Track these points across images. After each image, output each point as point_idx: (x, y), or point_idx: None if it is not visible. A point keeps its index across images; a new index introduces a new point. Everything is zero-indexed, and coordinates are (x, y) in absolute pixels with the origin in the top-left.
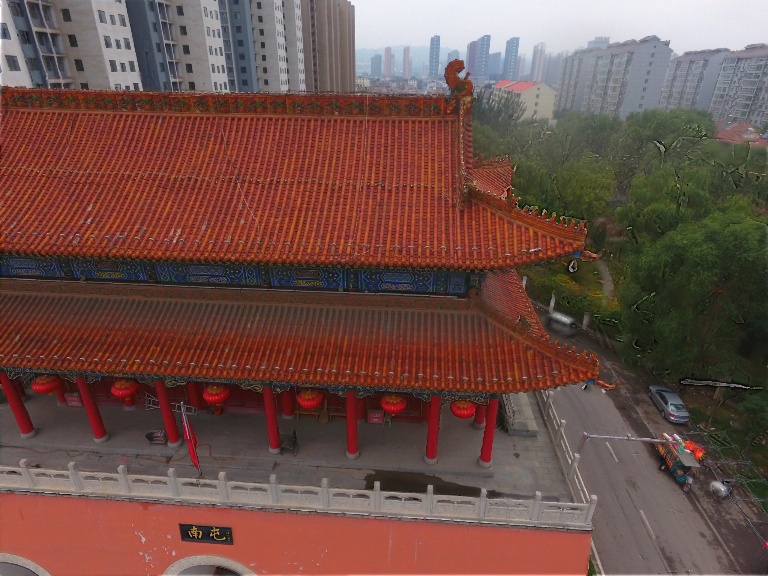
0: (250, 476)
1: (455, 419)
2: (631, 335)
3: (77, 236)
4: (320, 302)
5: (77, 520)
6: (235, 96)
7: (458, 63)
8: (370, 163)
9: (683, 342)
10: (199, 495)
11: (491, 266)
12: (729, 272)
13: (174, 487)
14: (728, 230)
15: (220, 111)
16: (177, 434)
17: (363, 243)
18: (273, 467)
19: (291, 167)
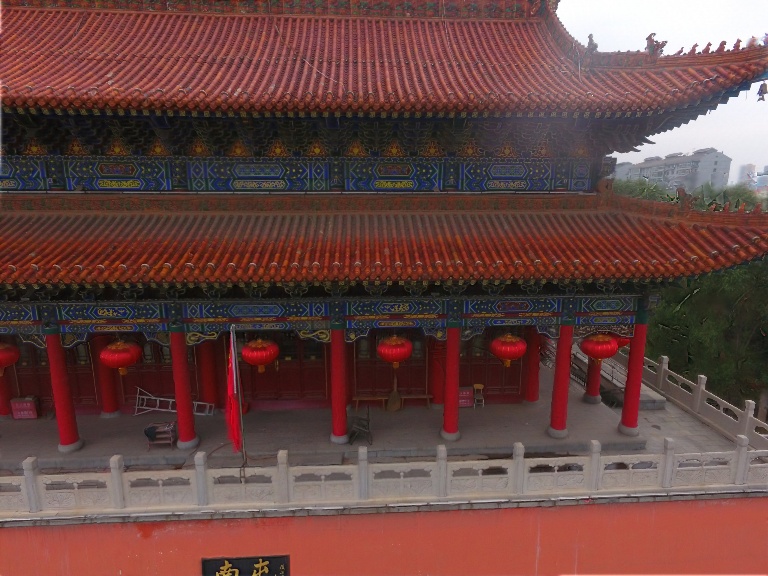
0: None
1: None
2: None
3: (94, 89)
4: (410, 207)
5: (21, 574)
6: None
7: None
8: None
9: (717, 360)
10: (241, 499)
11: (659, 102)
12: (757, 271)
13: (202, 486)
14: None
15: (271, 11)
16: (192, 428)
17: None
18: (342, 461)
19: (367, 52)
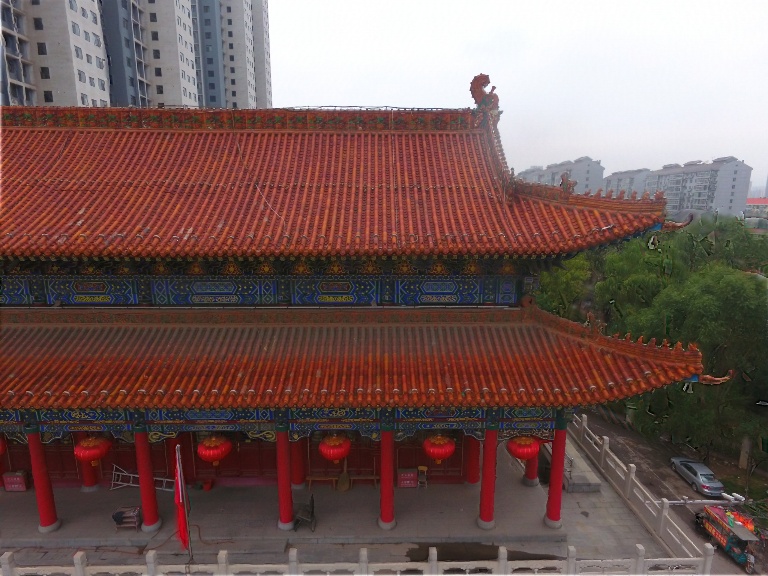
0: (255, 562)
1: (501, 477)
2: (643, 401)
3: (63, 235)
4: (350, 320)
5: None
6: (253, 112)
7: (484, 78)
8: (401, 170)
9: (698, 404)
10: None
11: (561, 248)
12: (734, 322)
13: None
14: (723, 281)
15: (235, 127)
16: (155, 512)
17: (409, 234)
18: (285, 548)
19: (316, 174)
